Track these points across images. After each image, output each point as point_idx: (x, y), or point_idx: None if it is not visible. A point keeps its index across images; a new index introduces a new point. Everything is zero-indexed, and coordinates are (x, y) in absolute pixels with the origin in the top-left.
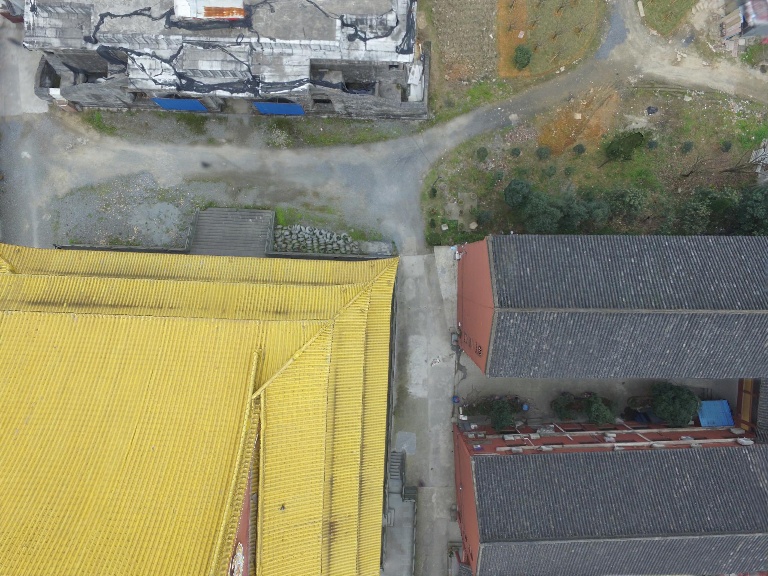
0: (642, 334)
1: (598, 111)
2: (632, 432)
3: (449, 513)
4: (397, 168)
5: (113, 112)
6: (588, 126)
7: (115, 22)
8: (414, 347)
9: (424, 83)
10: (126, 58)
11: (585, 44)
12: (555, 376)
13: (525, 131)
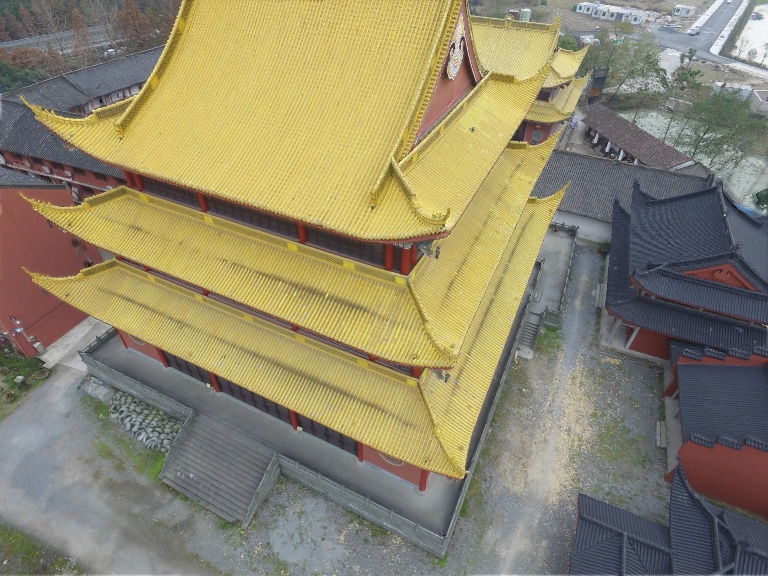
0: None
1: None
2: None
3: None
4: None
5: None
6: None
7: None
8: None
9: None
10: None
11: None
12: None
13: None
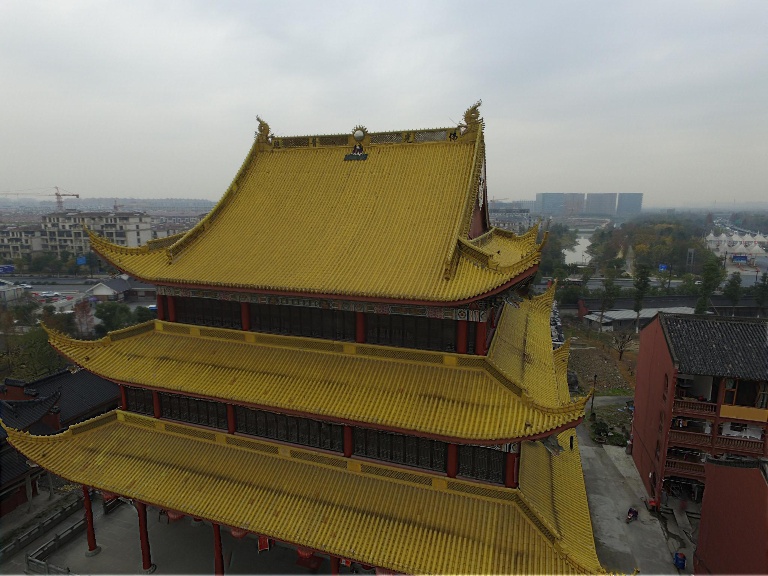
0: None
1: None
2: None
3: None
4: None
5: None
6: None
7: None
8: (598, 504)
9: None
10: None
11: None
12: None
13: None
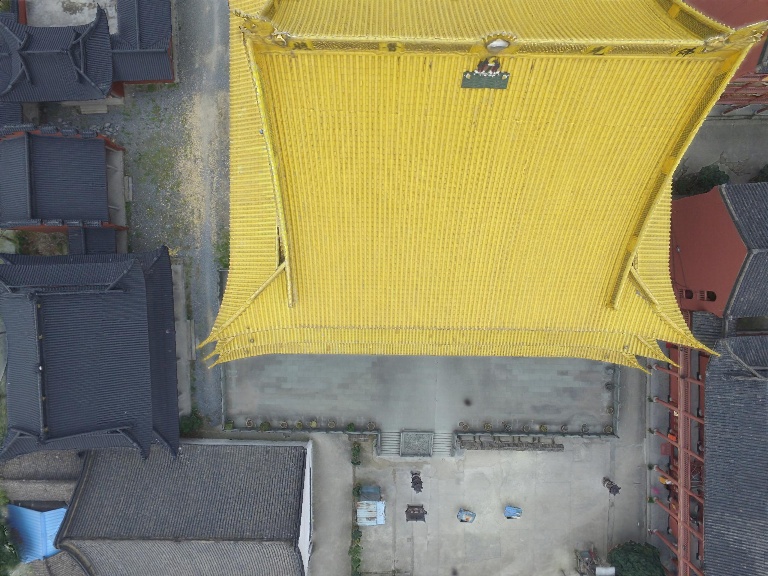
0: None
1: None
2: None
3: None
4: None
5: None
6: None
7: None
8: None
9: None
10: None
11: None
12: None
13: None
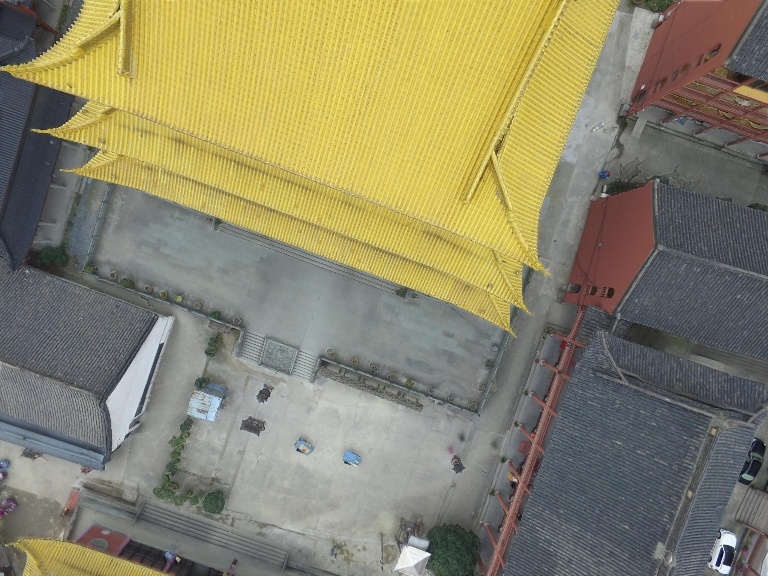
0: None
1: None
2: None
3: (557, 293)
4: None
5: None
6: None
7: None
8: None
9: None
10: None
11: None
12: None
13: None
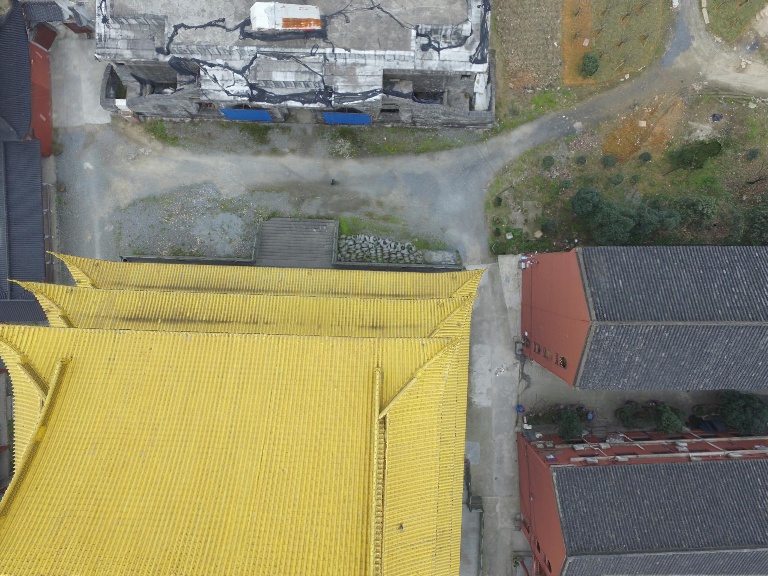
0: (736, 346)
1: (663, 119)
2: (702, 441)
3: (513, 523)
4: (461, 177)
5: (176, 122)
6: (653, 134)
7: (189, 33)
8: (478, 356)
9: (491, 92)
10: (197, 69)
11: (650, 51)
12: (643, 388)
13: (589, 139)
